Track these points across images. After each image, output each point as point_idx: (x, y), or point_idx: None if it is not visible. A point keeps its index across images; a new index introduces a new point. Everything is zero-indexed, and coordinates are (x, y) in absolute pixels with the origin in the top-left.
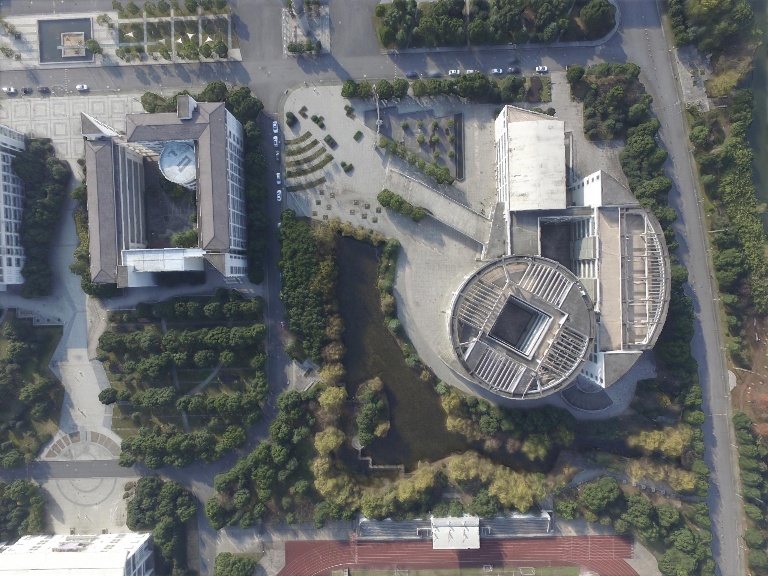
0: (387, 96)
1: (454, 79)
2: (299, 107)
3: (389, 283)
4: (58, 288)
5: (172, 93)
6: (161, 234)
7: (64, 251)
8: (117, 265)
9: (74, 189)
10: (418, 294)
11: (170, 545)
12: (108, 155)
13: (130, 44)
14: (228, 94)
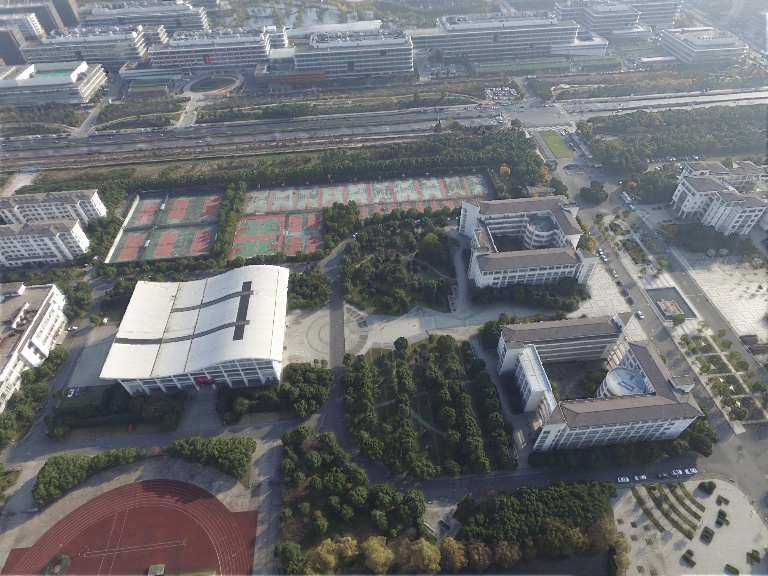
0: None
1: None
2: (725, 495)
3: None
4: (479, 308)
5: None
6: None
7: (509, 310)
8: None
9: None
10: None
11: (274, 396)
12: (608, 331)
13: (694, 344)
14: None
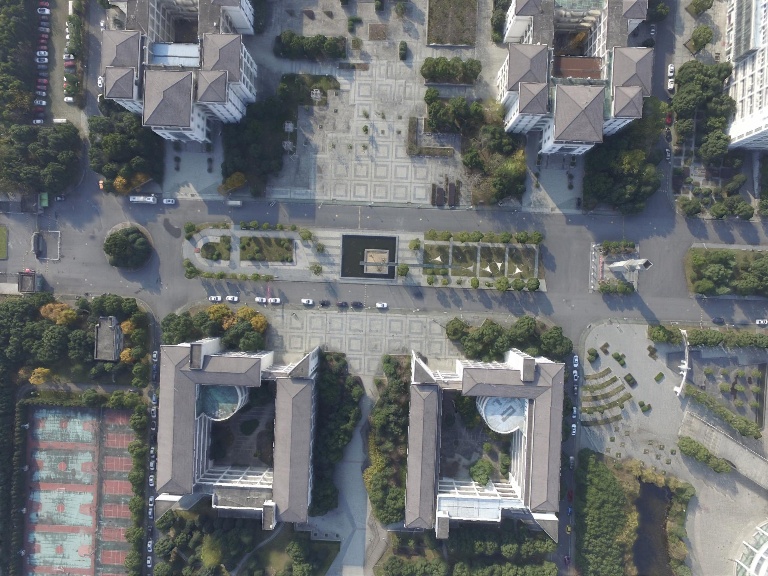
0: (697, 344)
1: (760, 328)
2: (601, 343)
3: (686, 533)
4: (339, 503)
5: (472, 318)
6: (449, 458)
7: (348, 467)
8: (433, 511)
9: (364, 406)
10: (706, 539)
11: None
12: (434, 401)
13: (434, 266)
14: (538, 331)
